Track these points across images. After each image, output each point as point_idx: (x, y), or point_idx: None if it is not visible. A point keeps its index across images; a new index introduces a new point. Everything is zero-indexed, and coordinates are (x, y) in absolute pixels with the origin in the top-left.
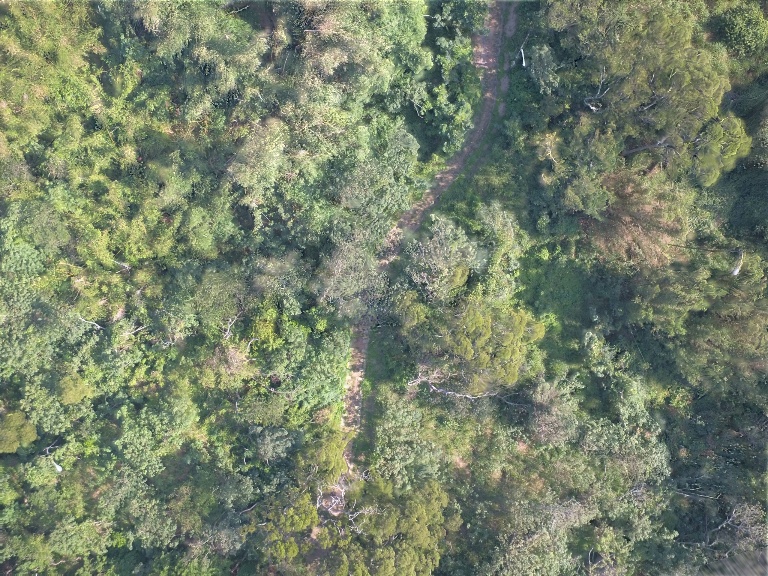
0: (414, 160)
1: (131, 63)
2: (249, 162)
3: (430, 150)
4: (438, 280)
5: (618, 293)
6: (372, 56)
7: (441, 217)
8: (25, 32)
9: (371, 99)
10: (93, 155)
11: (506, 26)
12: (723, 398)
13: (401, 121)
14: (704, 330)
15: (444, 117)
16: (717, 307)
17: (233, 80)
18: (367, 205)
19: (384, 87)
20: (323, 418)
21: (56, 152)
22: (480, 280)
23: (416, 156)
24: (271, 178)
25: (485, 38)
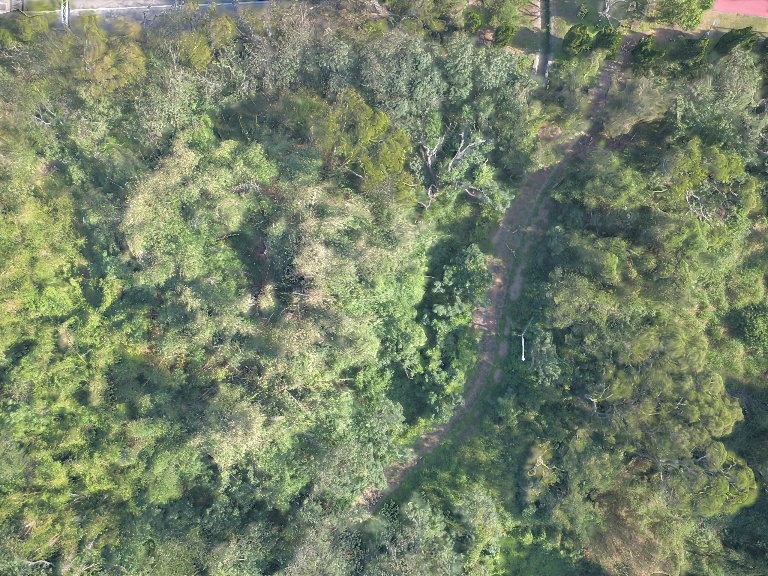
0: None
1: (112, 280)
2: (220, 429)
3: (418, 409)
4: None
5: None
6: (362, 328)
7: (422, 484)
8: (4, 238)
9: None
10: (60, 383)
11: (511, 287)
12: None
13: (390, 374)
14: None
15: (435, 383)
16: None
17: (214, 325)
18: (341, 488)
19: (373, 352)
20: None
21: (23, 371)
22: None
23: None
24: (242, 446)
25: None
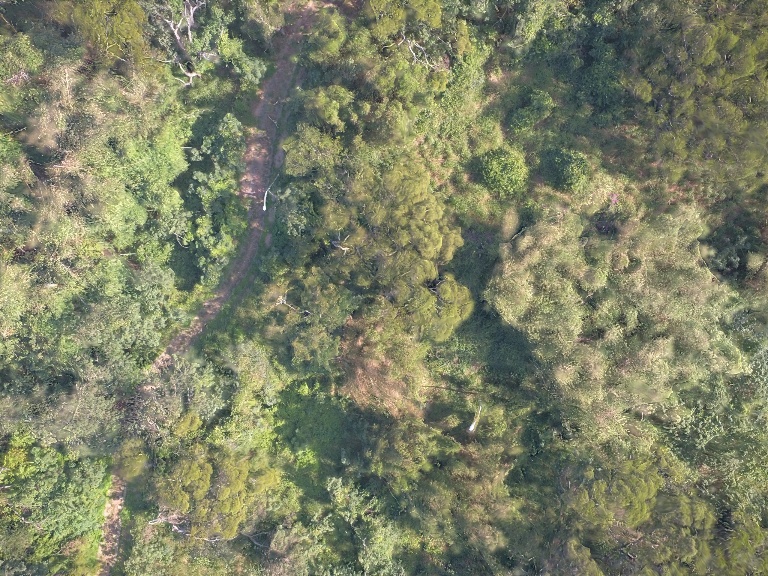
0: (174, 291)
1: None
2: None
3: (198, 278)
4: (168, 426)
5: (364, 438)
6: (119, 194)
7: (204, 347)
8: None
9: (139, 226)
10: None
11: (276, 156)
12: (467, 550)
13: (171, 248)
14: (434, 487)
15: (205, 249)
16: (449, 464)
17: None
18: (108, 344)
19: (139, 220)
20: (70, 551)
21: None
22: (219, 423)
23: (177, 287)
24: (16, 312)
25: (254, 168)
